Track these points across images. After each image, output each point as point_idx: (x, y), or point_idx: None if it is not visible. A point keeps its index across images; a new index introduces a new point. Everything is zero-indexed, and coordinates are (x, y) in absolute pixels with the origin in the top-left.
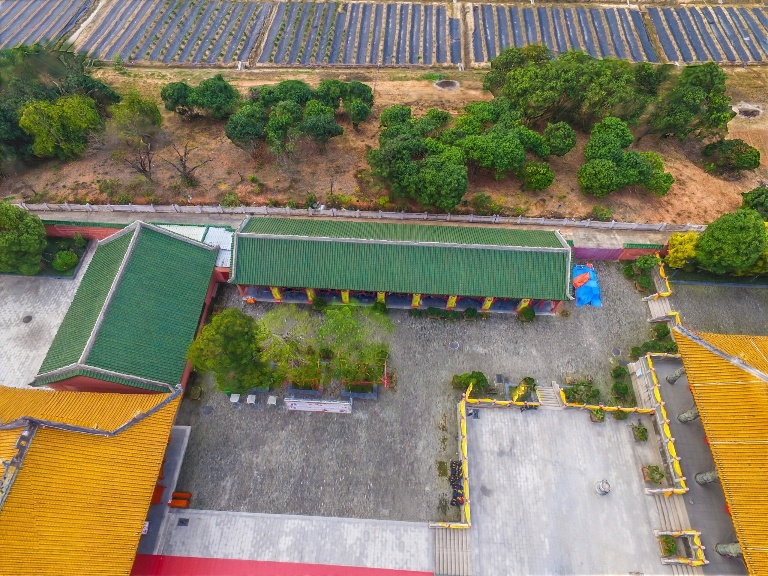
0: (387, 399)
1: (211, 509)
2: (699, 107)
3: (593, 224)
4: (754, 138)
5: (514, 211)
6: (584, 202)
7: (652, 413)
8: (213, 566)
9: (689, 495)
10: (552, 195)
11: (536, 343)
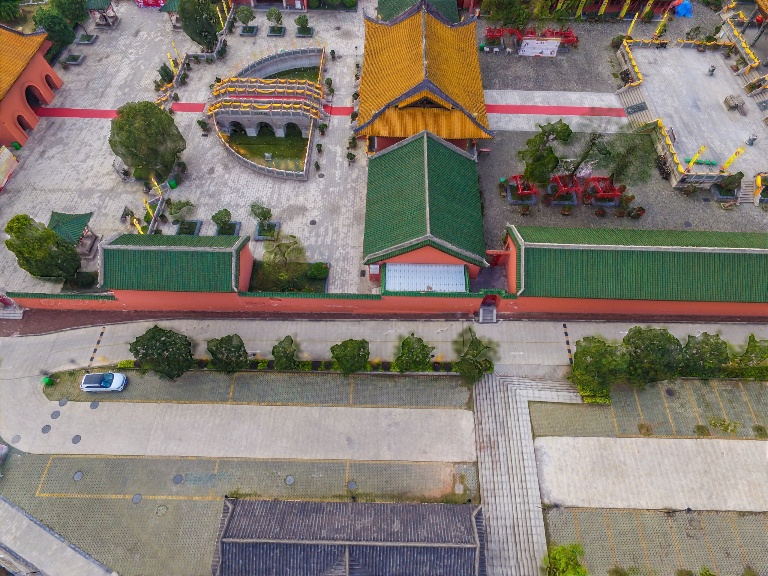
0: (574, 52)
1: (491, 89)
2: None
3: None
4: None
5: None
6: None
7: (733, 46)
8: (502, 107)
9: (759, 70)
10: None
11: None
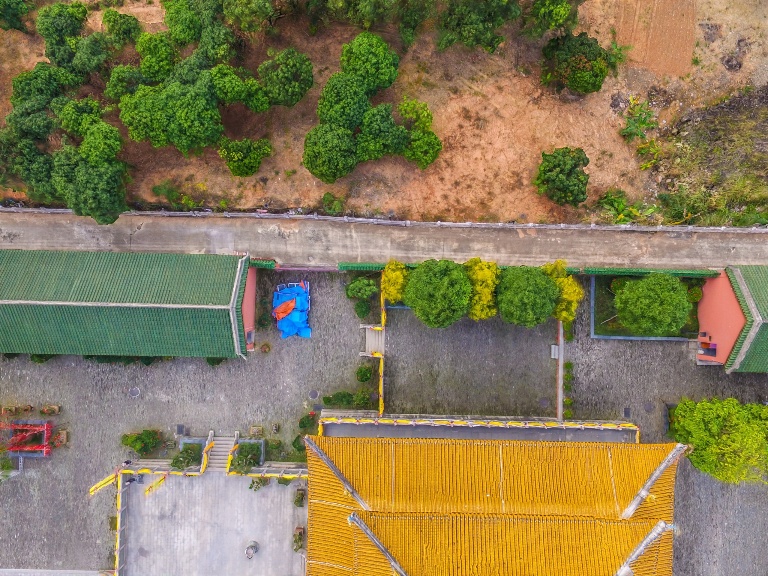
0: (60, 456)
1: None
2: (509, 6)
3: (324, 217)
4: (645, 5)
5: None
6: (320, 180)
7: None
8: None
9: None
10: (278, 169)
11: (226, 387)
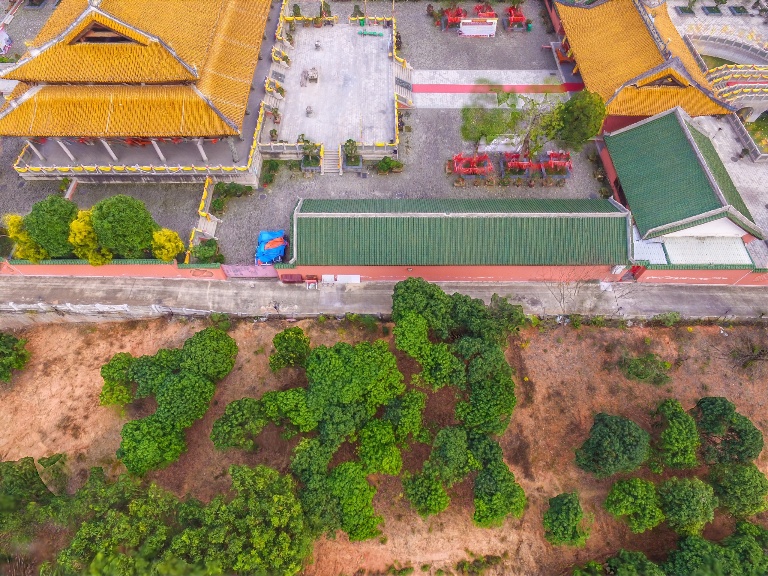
0: None
1: None
2: None
3: None
4: None
5: (326, 324)
6: None
7: None
8: (534, 91)
9: None
10: None
11: None
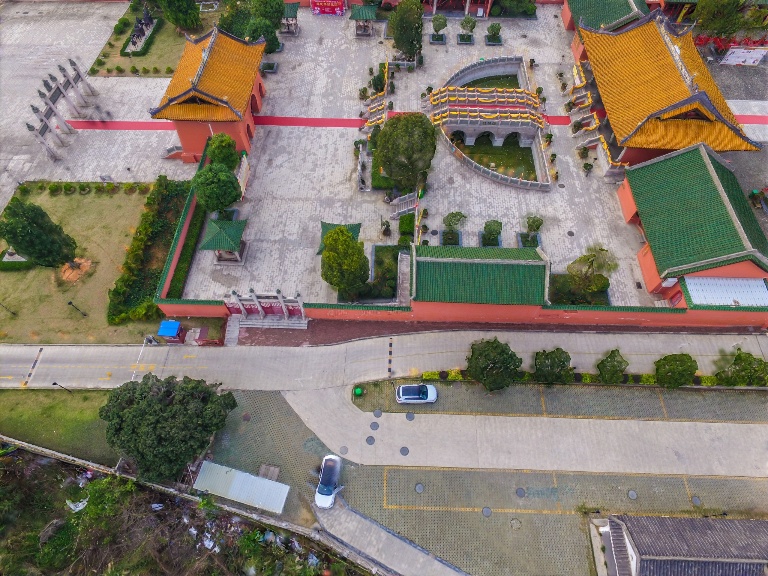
0: None
1: None
2: None
3: None
4: None
5: None
6: None
7: None
8: None
9: None
10: None
11: None
